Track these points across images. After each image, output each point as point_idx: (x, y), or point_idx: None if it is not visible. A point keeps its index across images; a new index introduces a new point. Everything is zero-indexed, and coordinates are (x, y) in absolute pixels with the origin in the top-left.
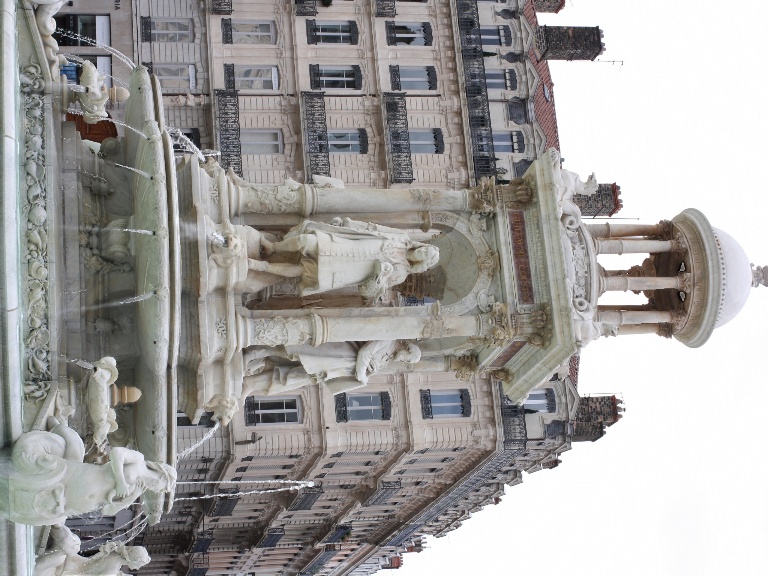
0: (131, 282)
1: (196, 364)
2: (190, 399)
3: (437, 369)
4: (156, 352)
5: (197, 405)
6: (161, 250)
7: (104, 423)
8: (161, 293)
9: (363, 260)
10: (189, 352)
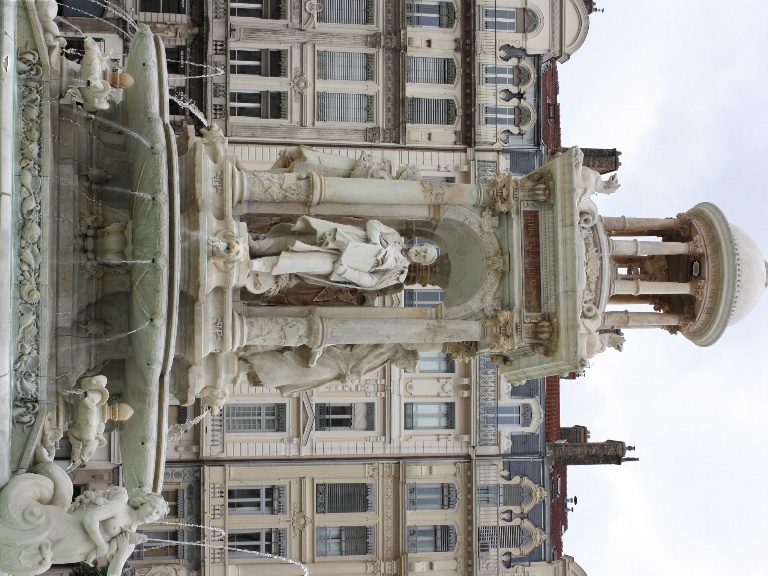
0: (121, 140)
1: (192, 175)
2: (191, 217)
3: (472, 327)
4: (146, 77)
5: (199, 209)
6: (144, 25)
7: (96, 74)
8: (146, 31)
9: (345, 157)
10: (183, 160)
